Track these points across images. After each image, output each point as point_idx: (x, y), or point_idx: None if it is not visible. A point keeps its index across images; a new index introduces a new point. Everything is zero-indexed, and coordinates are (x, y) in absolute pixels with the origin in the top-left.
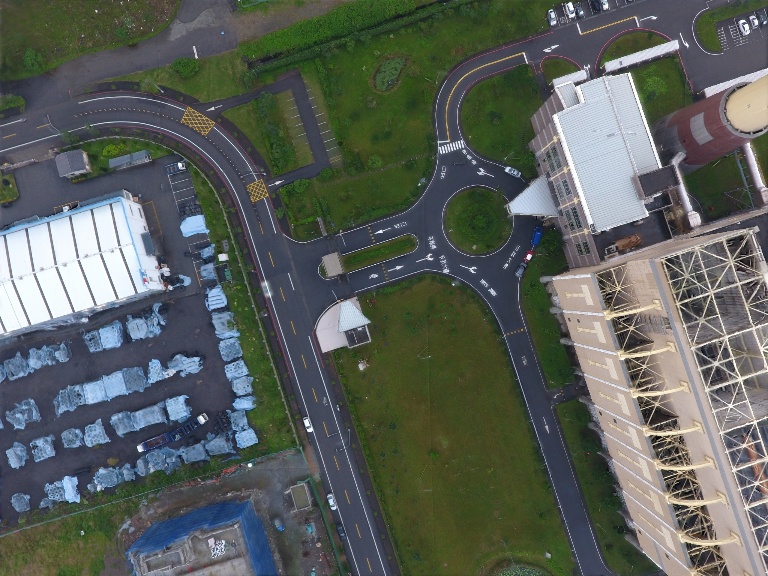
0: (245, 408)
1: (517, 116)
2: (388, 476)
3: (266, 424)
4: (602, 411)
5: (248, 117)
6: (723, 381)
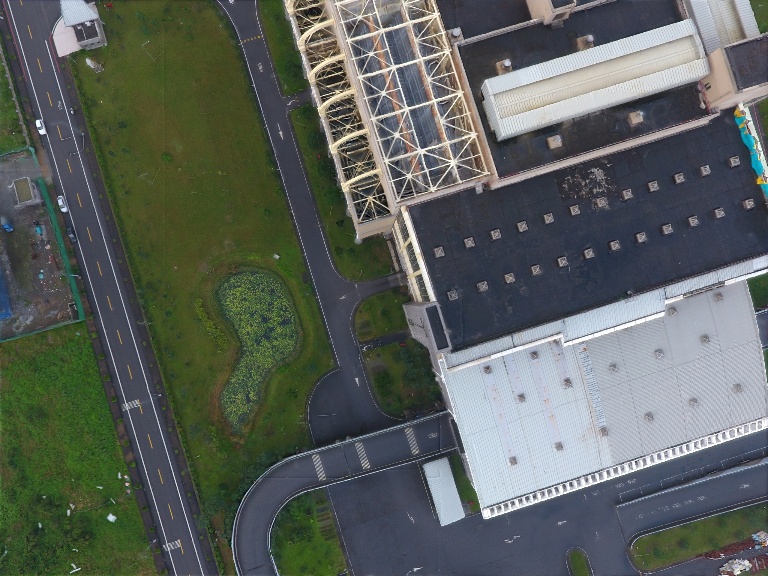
0: None
1: None
2: (121, 180)
3: None
4: (312, 90)
5: None
6: None
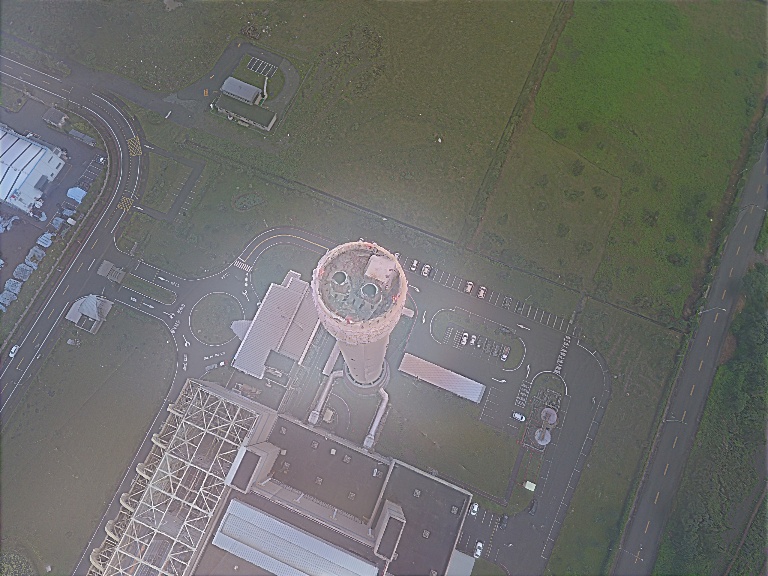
0: None
1: None
2: None
3: None
4: None
5: None
6: None
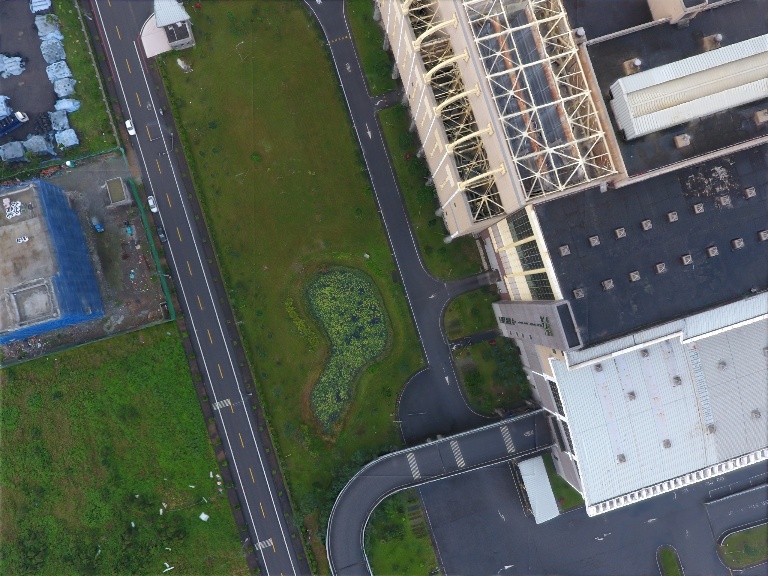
0: (66, 109)
1: None
2: (210, 180)
3: None
4: (408, 89)
5: None
6: None
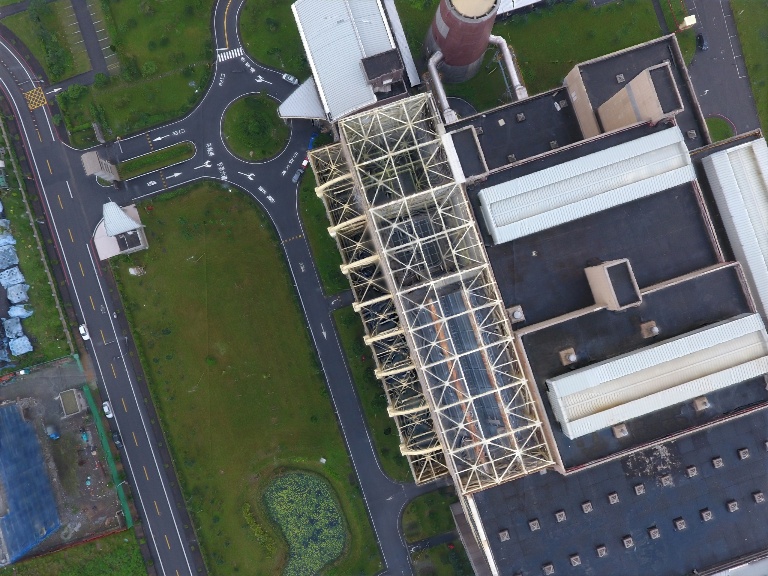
0: (20, 316)
1: (295, 24)
2: (165, 383)
3: (42, 332)
4: None
5: (27, 25)
6: (441, 260)
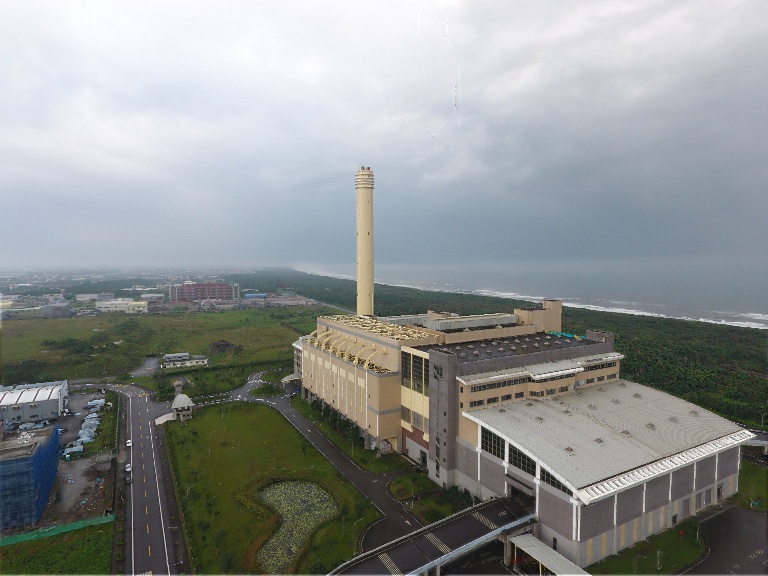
0: (83, 441)
1: None
2: (184, 455)
3: None
4: None
5: None
6: None
